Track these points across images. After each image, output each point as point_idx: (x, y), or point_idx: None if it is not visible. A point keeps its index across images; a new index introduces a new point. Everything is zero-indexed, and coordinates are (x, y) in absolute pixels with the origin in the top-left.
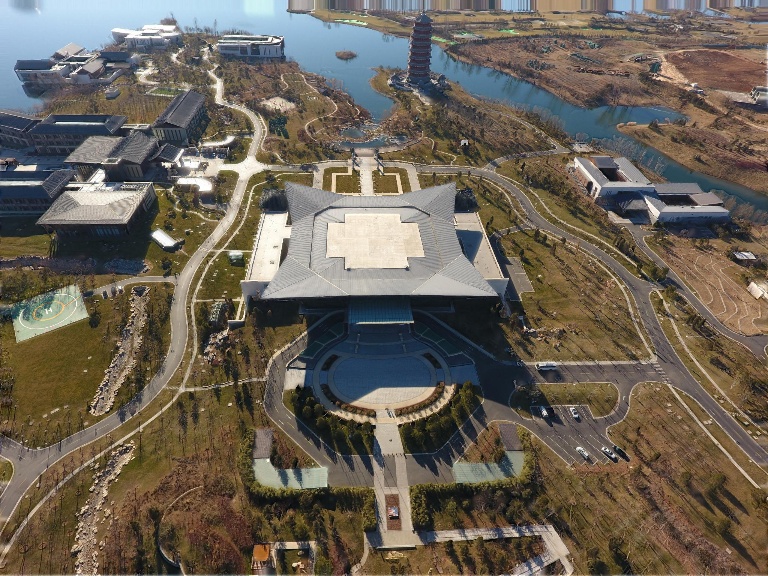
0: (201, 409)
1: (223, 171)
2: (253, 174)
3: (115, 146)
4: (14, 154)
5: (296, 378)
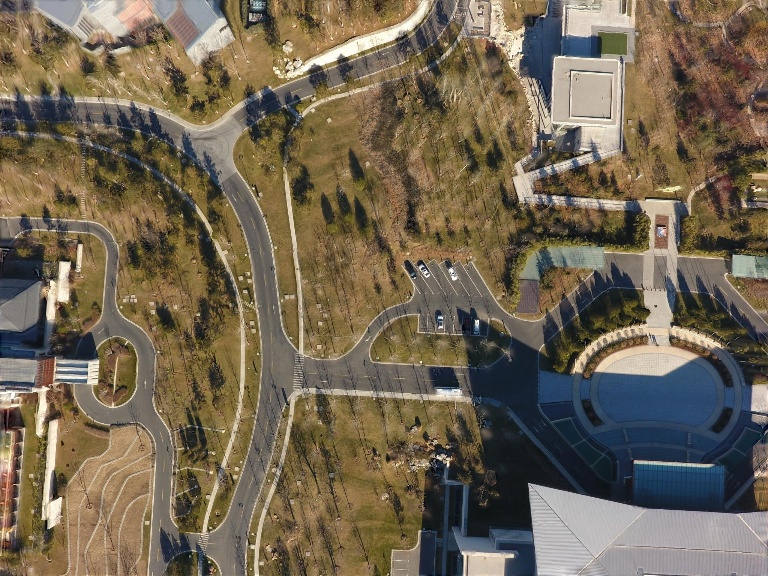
0: None
1: None
2: None
3: None
4: None
5: (762, 400)
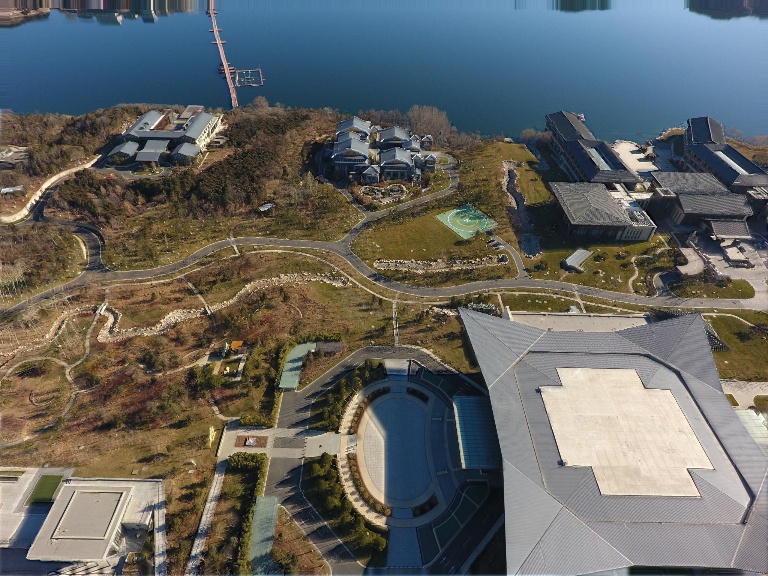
0: (372, 312)
1: (745, 282)
2: (763, 311)
3: (706, 191)
4: (667, 155)
5: (398, 368)
